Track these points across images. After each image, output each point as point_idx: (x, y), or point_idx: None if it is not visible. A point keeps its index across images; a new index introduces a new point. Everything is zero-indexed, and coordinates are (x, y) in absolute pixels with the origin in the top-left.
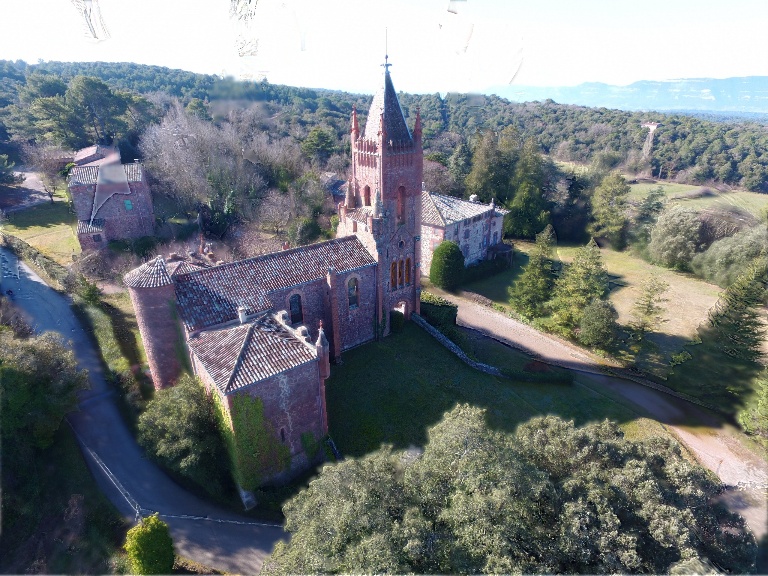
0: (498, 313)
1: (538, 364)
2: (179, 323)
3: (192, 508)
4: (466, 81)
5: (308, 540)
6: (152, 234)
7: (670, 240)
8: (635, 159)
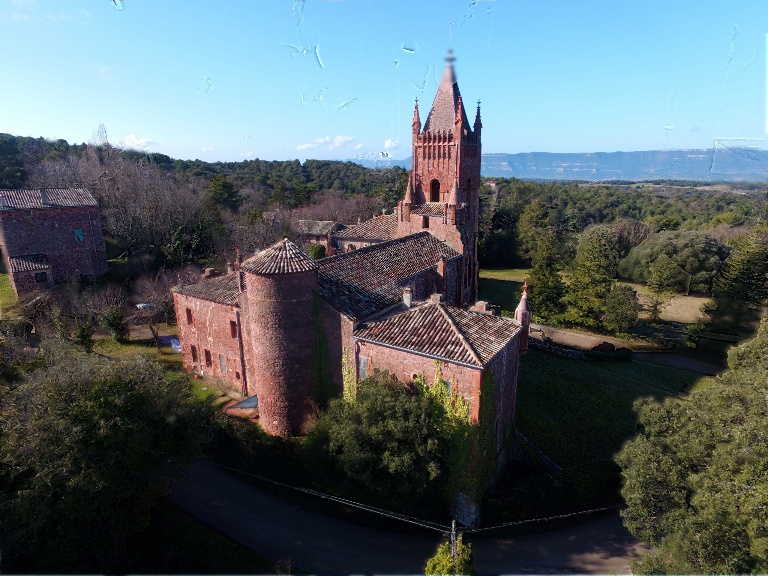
0: None
1: (607, 344)
2: (322, 320)
3: (411, 547)
4: (411, 117)
5: None
6: None
7: None
8: (548, 188)
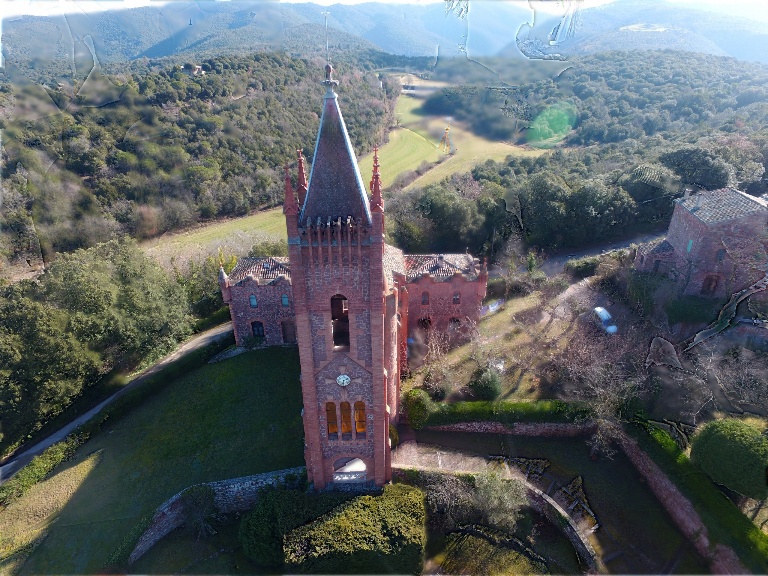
0: None
1: (100, 575)
2: None
3: None
4: None
5: None
6: (685, 293)
7: None
8: None
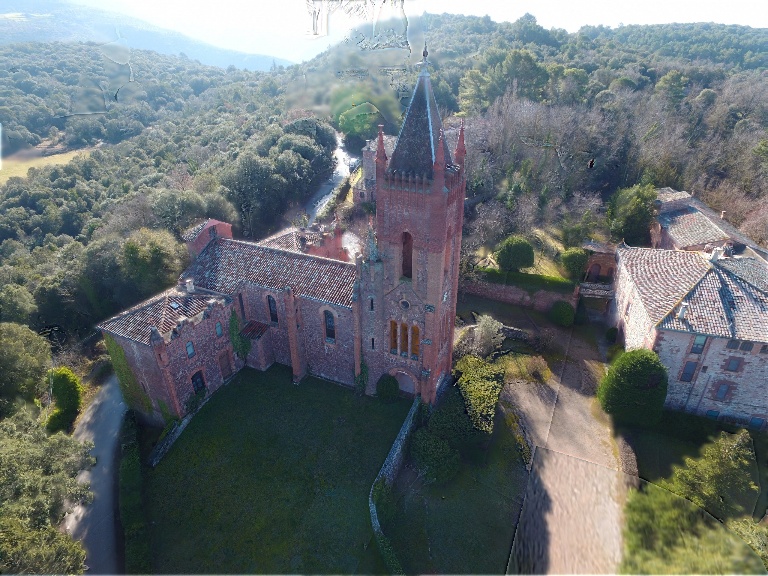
0: None
1: None
2: None
3: None
4: None
5: None
6: None
7: None
8: None
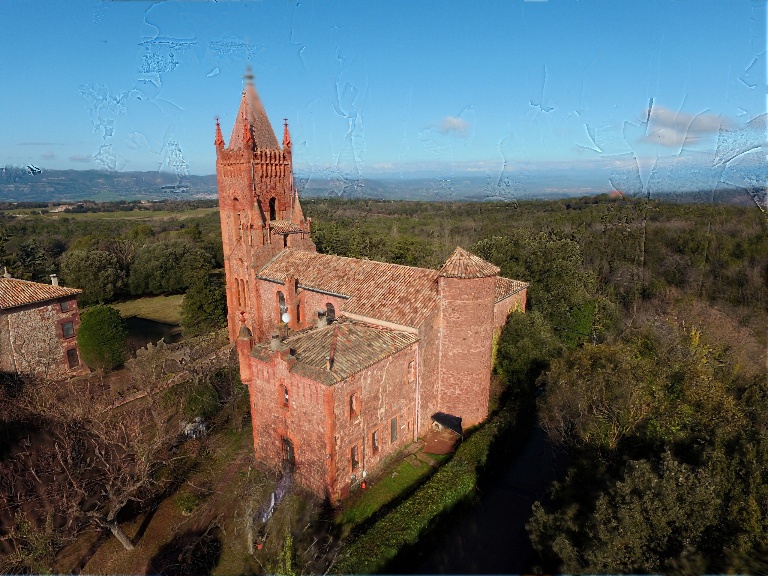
0: None
1: None
2: None
3: None
4: None
5: None
6: None
7: (107, 275)
8: None
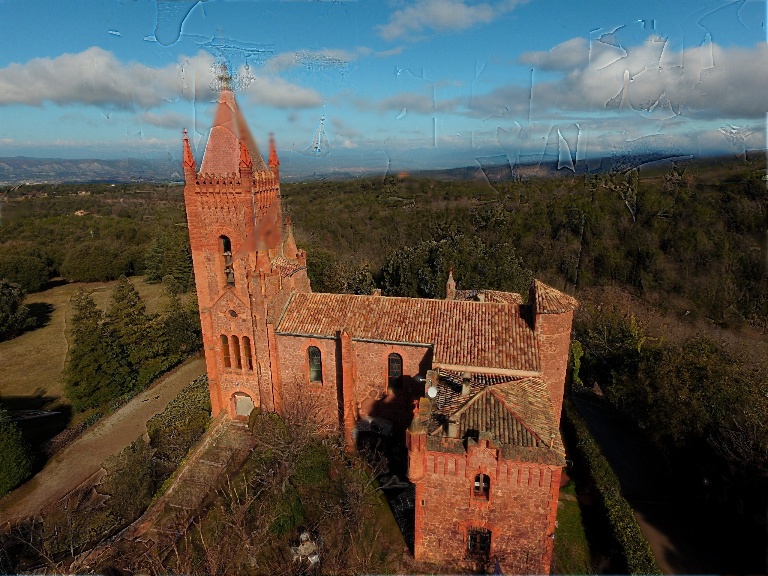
0: (103, 421)
1: None
2: None
3: None
4: None
5: (519, 261)
6: None
7: None
8: None
